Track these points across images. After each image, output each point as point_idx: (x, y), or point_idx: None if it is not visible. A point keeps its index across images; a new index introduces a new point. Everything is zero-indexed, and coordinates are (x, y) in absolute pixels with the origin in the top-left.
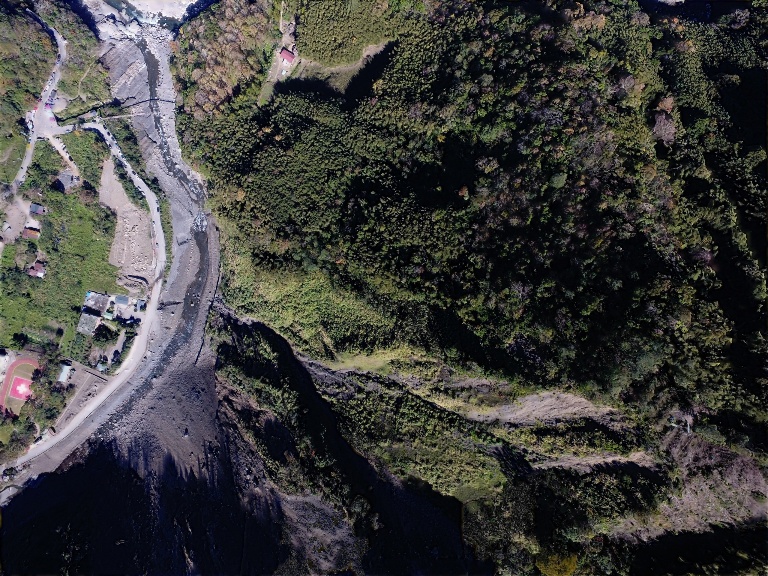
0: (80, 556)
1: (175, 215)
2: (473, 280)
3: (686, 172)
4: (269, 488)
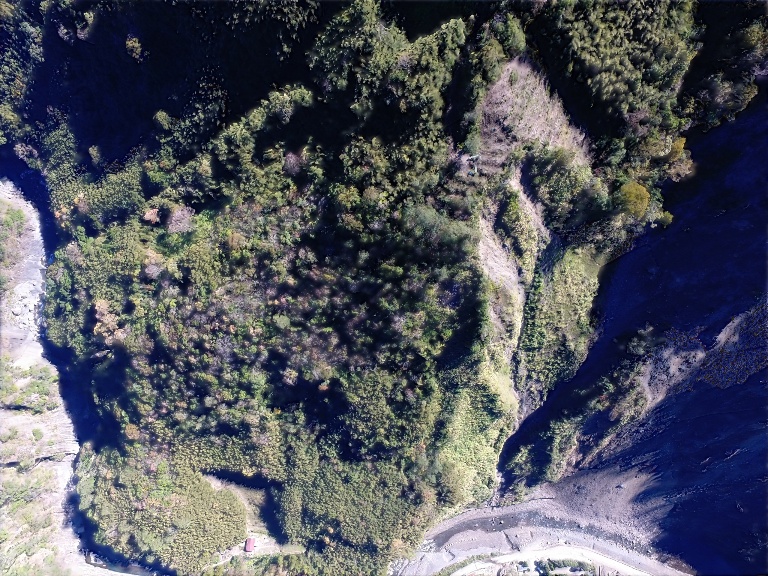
0: (765, 537)
1: (430, 571)
2: (402, 353)
3: (211, 184)
4: (646, 414)
